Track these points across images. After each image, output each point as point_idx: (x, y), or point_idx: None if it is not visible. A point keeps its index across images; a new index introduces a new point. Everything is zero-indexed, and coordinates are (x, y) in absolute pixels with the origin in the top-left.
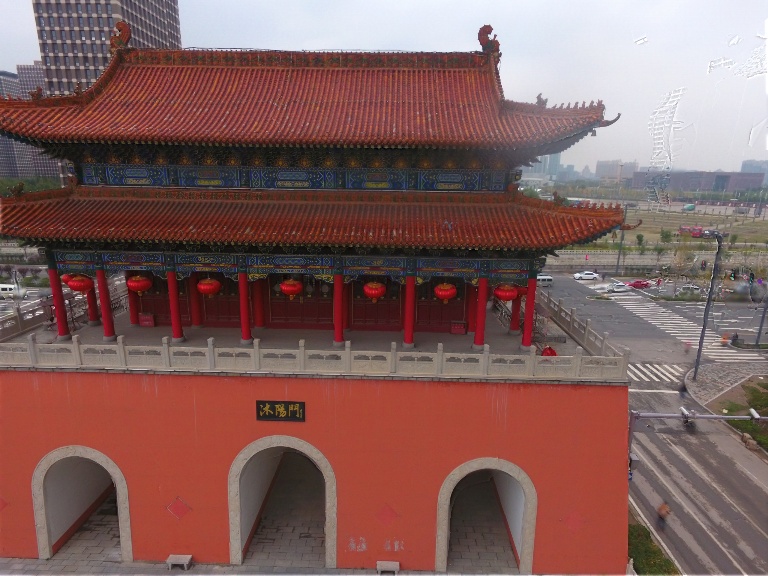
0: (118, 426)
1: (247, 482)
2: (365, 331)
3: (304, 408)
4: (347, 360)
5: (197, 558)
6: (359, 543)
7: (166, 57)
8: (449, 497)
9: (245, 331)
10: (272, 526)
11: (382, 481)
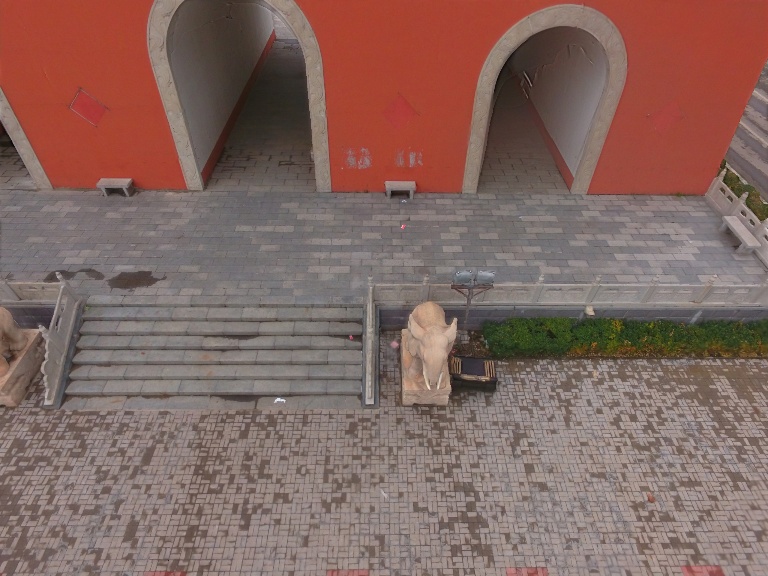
0: None
1: (186, 75)
2: None
3: None
4: None
5: (140, 183)
6: (360, 157)
7: None
8: (494, 80)
9: None
10: (240, 155)
11: (393, 55)
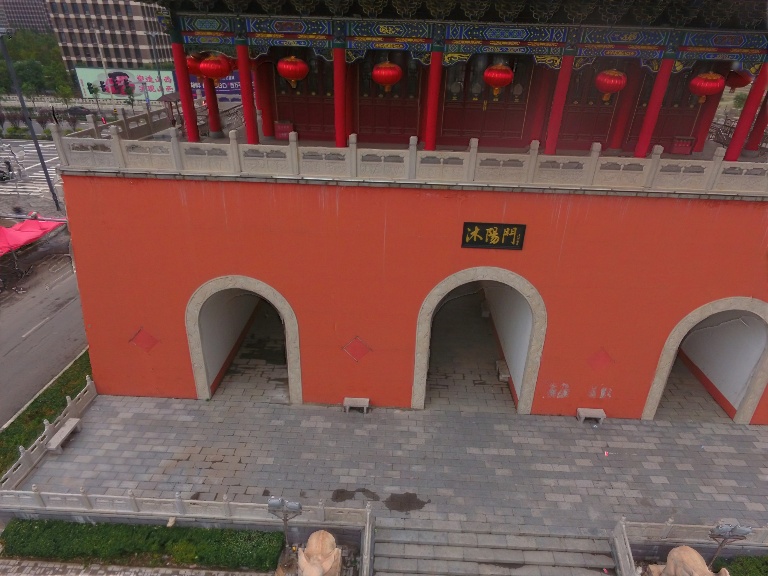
0: (287, 253)
1: None
2: (560, 150)
3: (524, 233)
4: (591, 169)
5: (374, 402)
6: (560, 389)
7: None
8: (679, 341)
9: (431, 138)
10: (438, 373)
11: (602, 322)
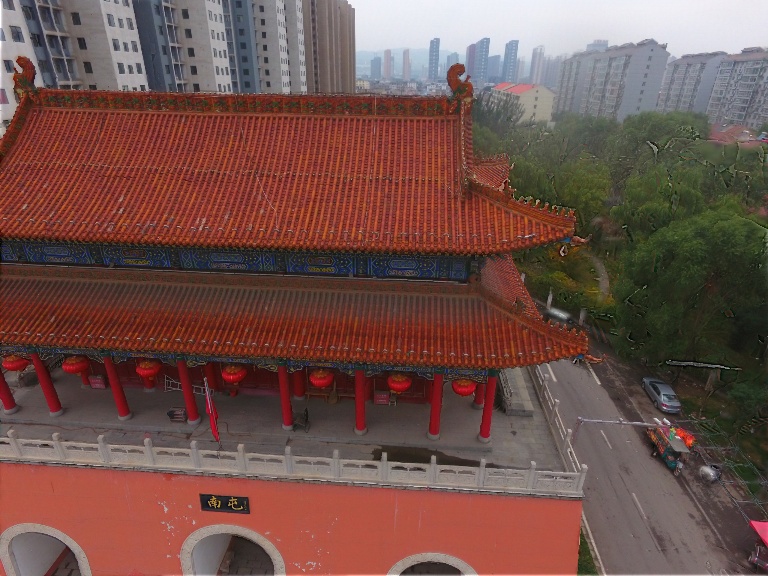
0: None
1: None
2: None
3: None
4: None
5: None
6: None
7: (403, 106)
8: None
9: None
10: None
11: None
